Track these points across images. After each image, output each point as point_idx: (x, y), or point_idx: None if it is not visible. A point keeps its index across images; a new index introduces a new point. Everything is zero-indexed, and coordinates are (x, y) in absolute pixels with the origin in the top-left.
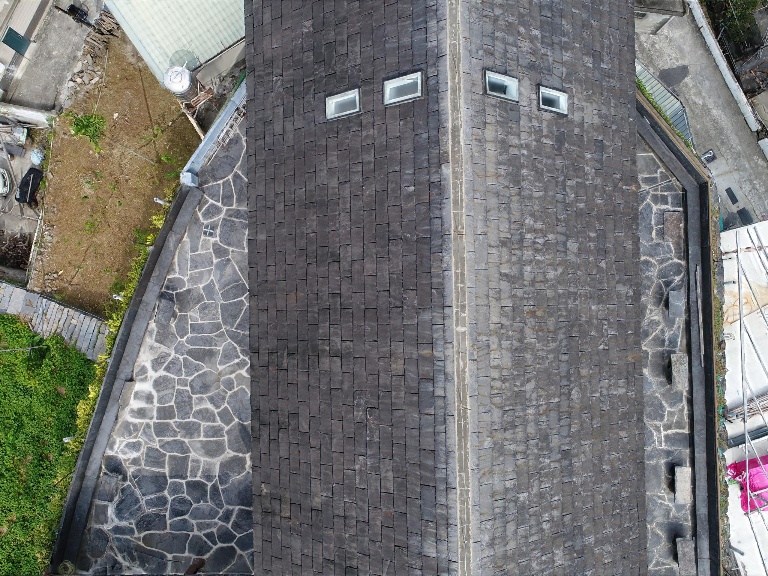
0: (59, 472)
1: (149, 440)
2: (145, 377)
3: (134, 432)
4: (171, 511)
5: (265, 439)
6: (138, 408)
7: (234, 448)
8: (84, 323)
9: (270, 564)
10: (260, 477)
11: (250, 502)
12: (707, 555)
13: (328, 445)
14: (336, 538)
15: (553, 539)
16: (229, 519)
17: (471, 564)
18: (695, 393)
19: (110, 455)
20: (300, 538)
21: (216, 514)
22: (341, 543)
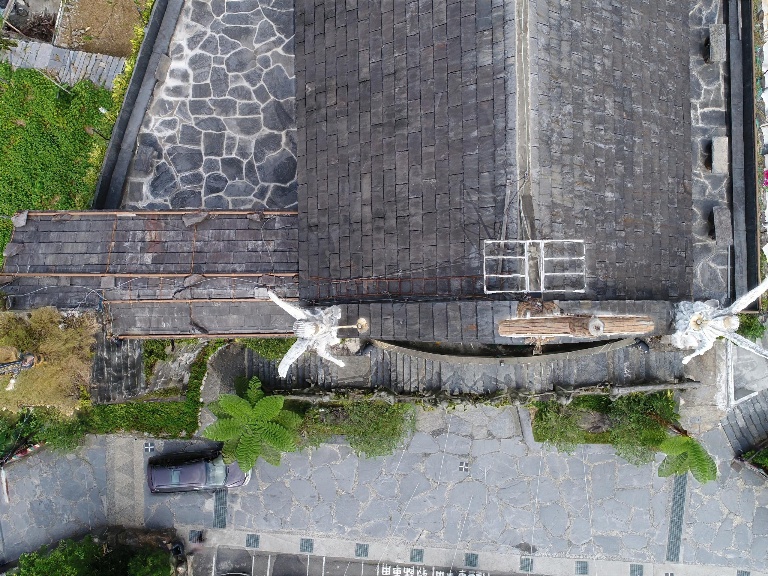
0: (95, 145)
1: (184, 118)
2: (181, 55)
3: (169, 110)
4: (206, 188)
5: (310, 38)
6: (174, 86)
7: (270, 125)
8: (113, 63)
9: (314, 161)
10: (304, 79)
11: (285, 179)
12: (743, 227)
13: (377, 10)
14: (385, 98)
15: (604, 85)
16: (264, 196)
17: (528, 56)
18: (732, 66)
19: (145, 133)
20: (347, 118)
21: (251, 191)
22: (390, 101)
